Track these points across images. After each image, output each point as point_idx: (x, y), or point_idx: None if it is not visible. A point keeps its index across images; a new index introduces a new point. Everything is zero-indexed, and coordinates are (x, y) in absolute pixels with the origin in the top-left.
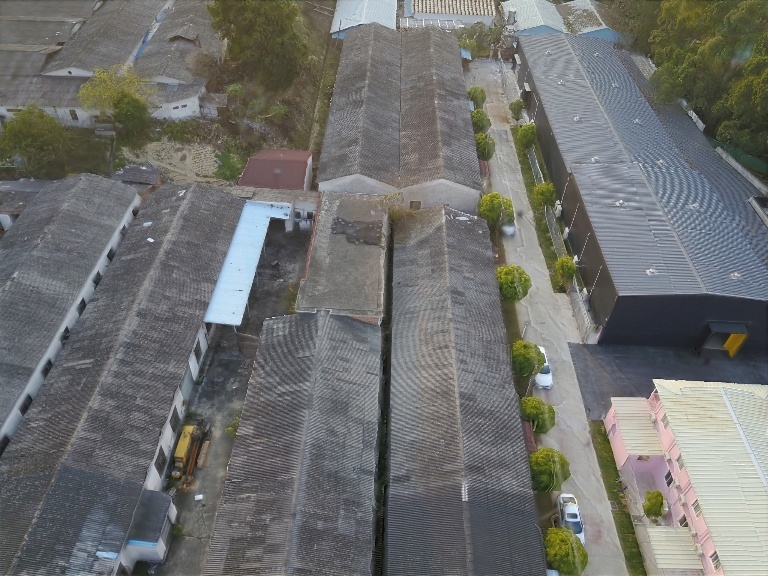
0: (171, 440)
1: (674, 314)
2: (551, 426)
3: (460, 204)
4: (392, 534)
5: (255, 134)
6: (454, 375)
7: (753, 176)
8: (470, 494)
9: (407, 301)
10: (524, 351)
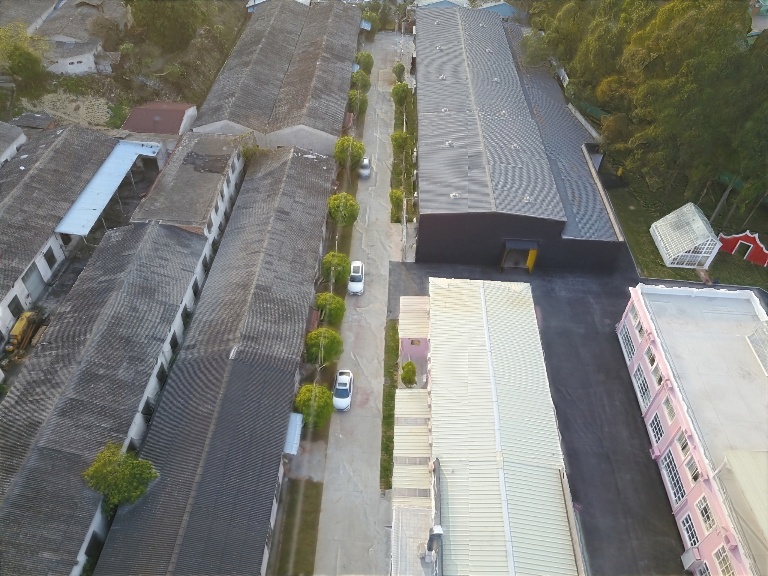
0: (10, 322)
1: (473, 232)
2: (339, 316)
3: (322, 149)
4: (169, 385)
5: (148, 90)
6: (256, 272)
7: (592, 127)
8: (238, 355)
9: (240, 220)
10: (331, 259)
